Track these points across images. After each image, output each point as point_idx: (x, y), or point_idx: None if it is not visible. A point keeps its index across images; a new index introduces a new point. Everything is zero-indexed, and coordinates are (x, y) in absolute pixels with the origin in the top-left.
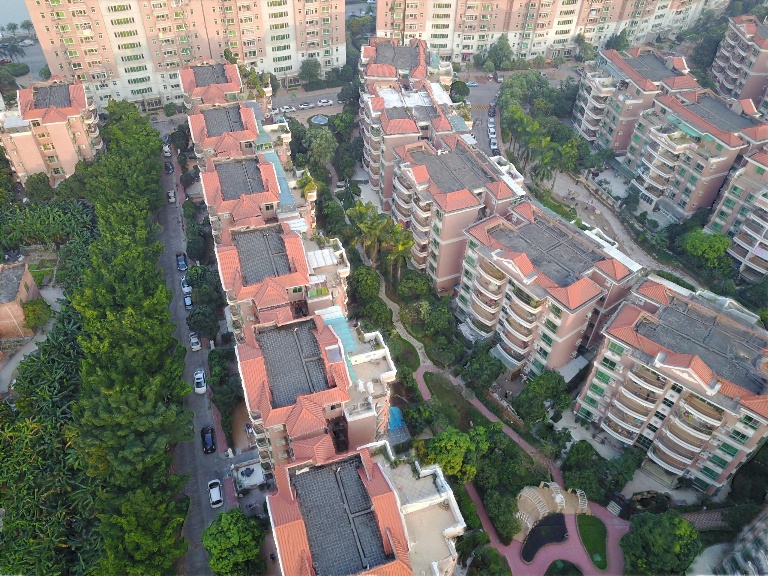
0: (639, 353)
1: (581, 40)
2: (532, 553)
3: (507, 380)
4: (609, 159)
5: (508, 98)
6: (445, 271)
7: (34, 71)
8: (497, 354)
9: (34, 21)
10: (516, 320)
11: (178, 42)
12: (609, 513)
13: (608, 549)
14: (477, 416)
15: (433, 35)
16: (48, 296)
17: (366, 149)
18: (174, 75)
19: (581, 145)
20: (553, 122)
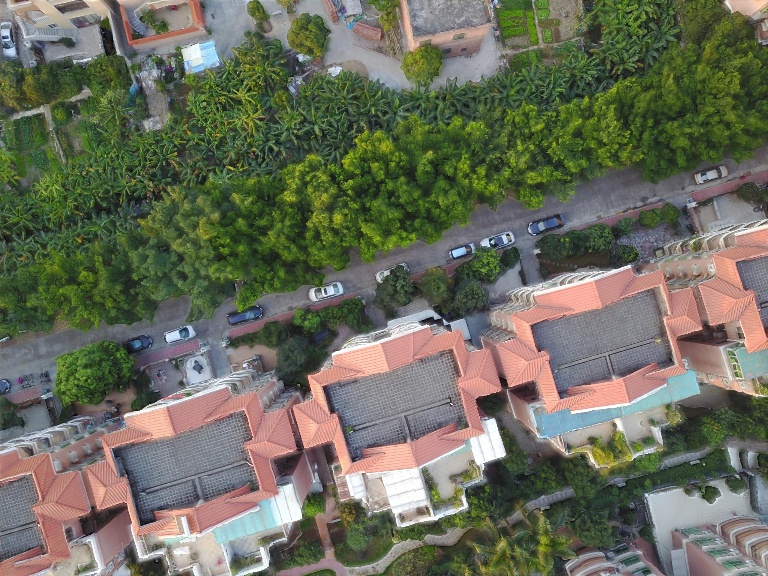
0: None
1: None
2: None
3: None
4: None
5: None
6: None
7: None
8: None
9: None
10: None
11: None
12: None
13: None
14: None
15: None
16: (483, 56)
17: None
18: None
19: None
20: None
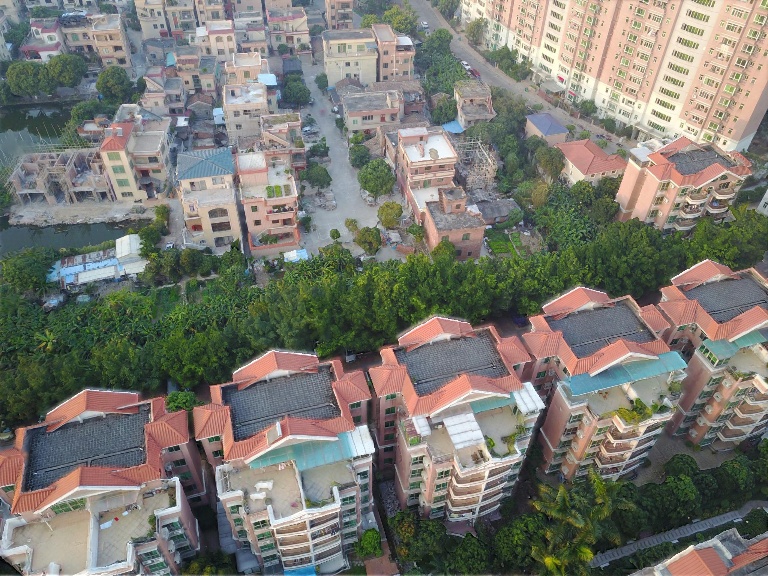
0: None
1: None
2: None
3: None
4: None
5: None
6: None
7: None
8: None
9: None
10: None
11: None
12: None
13: None
14: None
15: None
16: None
17: None
18: None
19: None
20: None
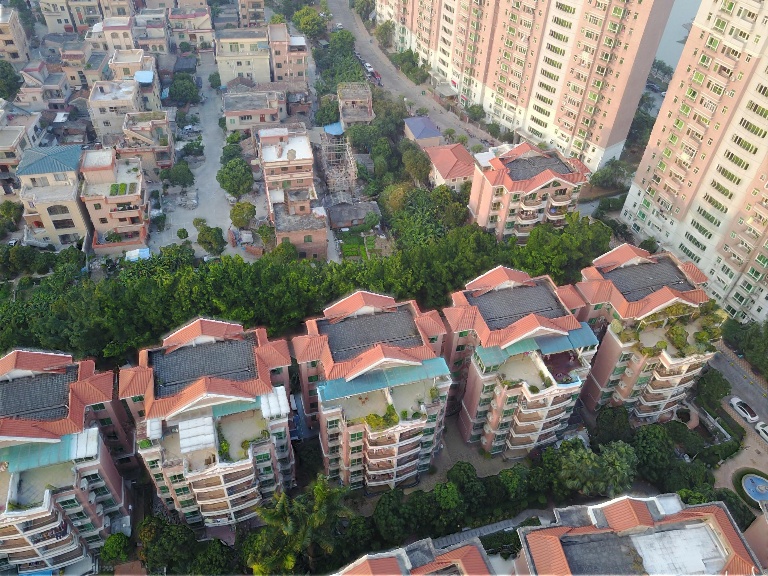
0: None
1: None
2: None
3: None
4: None
5: None
6: None
7: None
8: None
9: (661, 114)
10: None
11: (764, 244)
12: None
13: None
14: None
15: None
16: None
17: None
18: (729, 270)
19: None
20: None
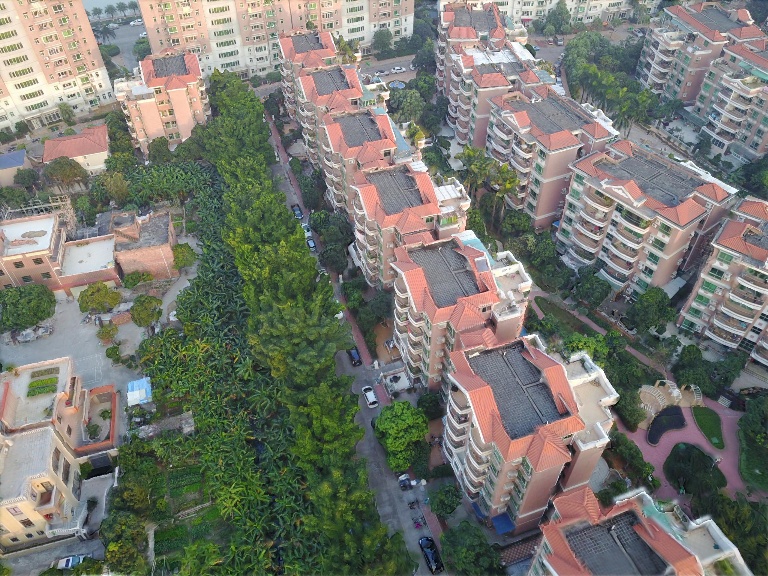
0: (749, 259)
1: (635, 2)
2: (658, 437)
3: (611, 301)
4: (678, 109)
5: (575, 57)
6: (543, 209)
7: (124, 52)
8: (601, 278)
9: (140, 0)
10: (624, 243)
11: (265, 16)
12: (721, 405)
13: (724, 434)
14: (589, 331)
15: (494, 3)
16: None
17: (451, 107)
18: (260, 48)
19: (650, 97)
20: (622, 77)
